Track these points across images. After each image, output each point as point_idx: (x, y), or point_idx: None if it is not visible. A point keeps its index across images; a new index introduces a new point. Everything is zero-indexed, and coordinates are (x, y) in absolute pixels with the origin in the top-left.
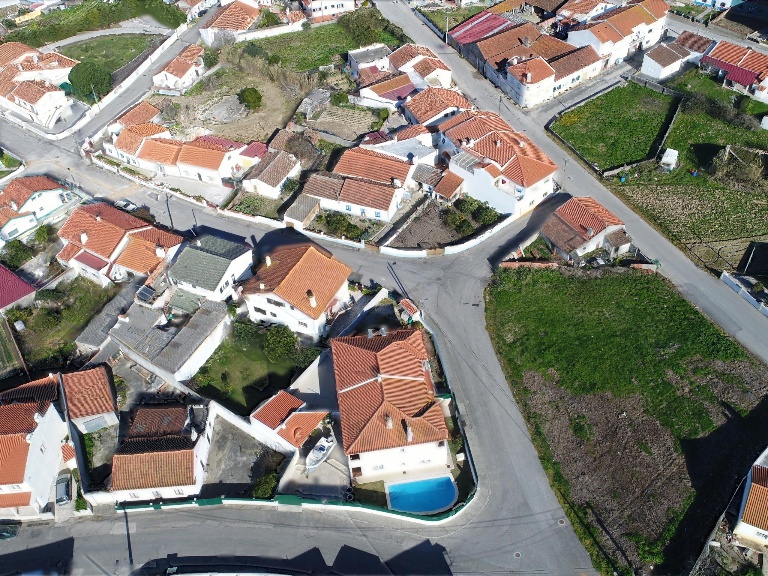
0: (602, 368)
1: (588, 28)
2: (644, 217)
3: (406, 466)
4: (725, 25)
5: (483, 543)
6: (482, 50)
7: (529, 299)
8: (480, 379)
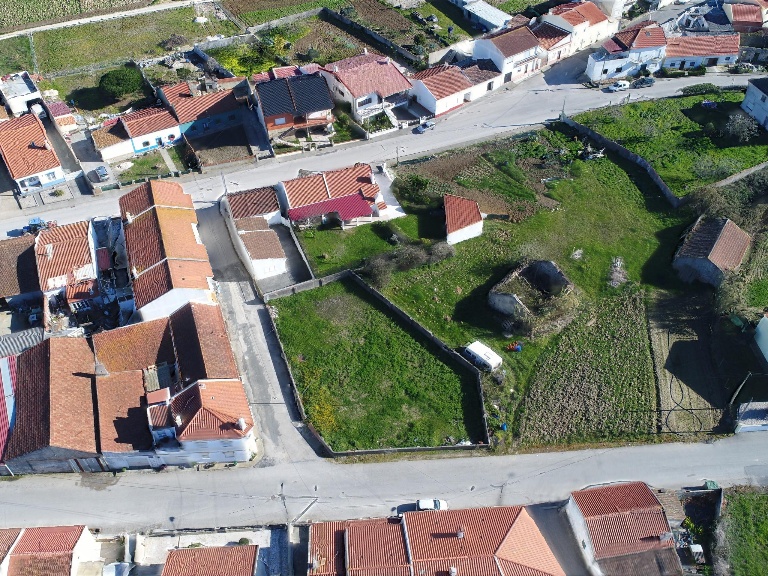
0: None
1: (170, 287)
2: (592, 445)
3: None
4: (213, 159)
5: None
6: (71, 446)
7: None
8: None
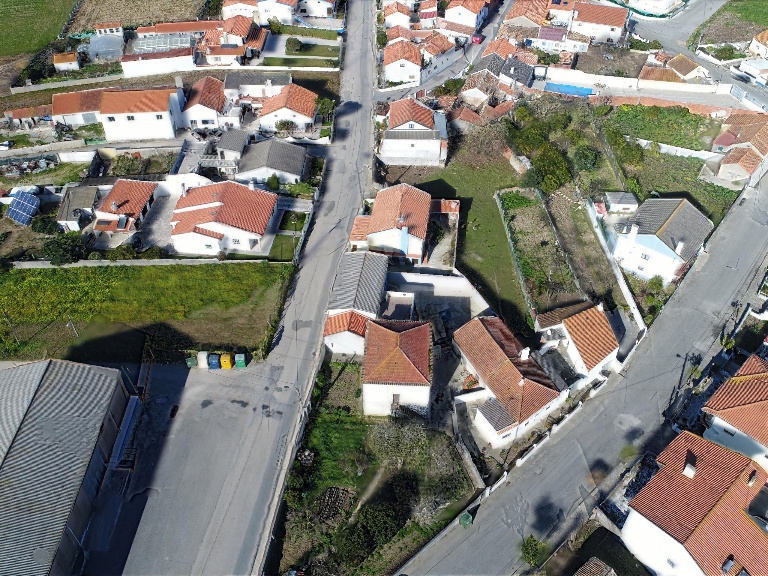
0: (763, 19)
1: None
2: None
3: (647, 6)
4: None
5: (654, 26)
6: None
7: (760, 0)
8: (705, 7)
